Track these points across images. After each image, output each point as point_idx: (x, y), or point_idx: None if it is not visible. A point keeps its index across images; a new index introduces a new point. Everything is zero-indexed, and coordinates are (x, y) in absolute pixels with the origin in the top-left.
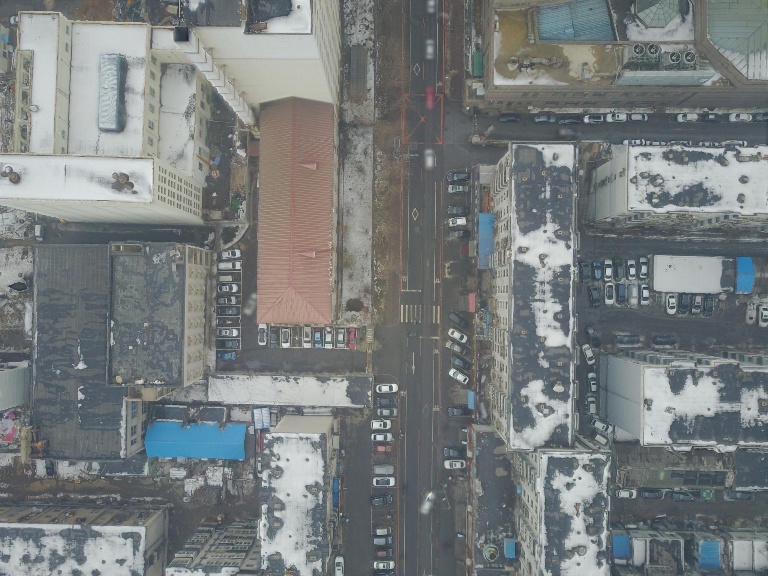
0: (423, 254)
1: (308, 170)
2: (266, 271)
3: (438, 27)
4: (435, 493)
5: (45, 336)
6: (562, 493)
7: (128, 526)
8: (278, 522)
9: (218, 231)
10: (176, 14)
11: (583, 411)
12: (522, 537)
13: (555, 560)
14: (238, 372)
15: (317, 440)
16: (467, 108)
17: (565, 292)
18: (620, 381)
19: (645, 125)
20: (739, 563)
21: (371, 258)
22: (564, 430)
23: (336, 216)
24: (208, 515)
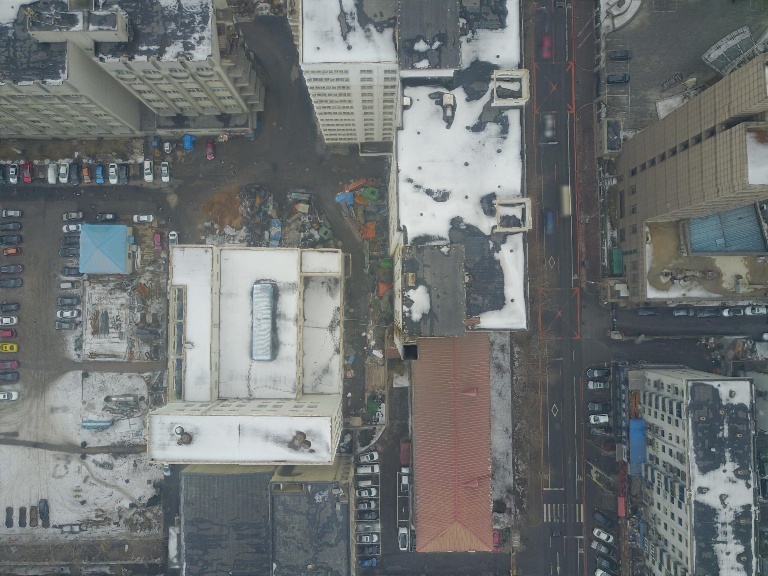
0: (564, 451)
1: (469, 397)
2: (426, 500)
3: (572, 220)
4: None
5: (194, 568)
6: None
7: None
8: None
9: (355, 433)
10: (307, 213)
11: None
12: None
13: None
14: None
15: None
16: (605, 303)
17: (747, 533)
18: None
19: None
20: None
21: (512, 457)
22: None
23: None
24: None
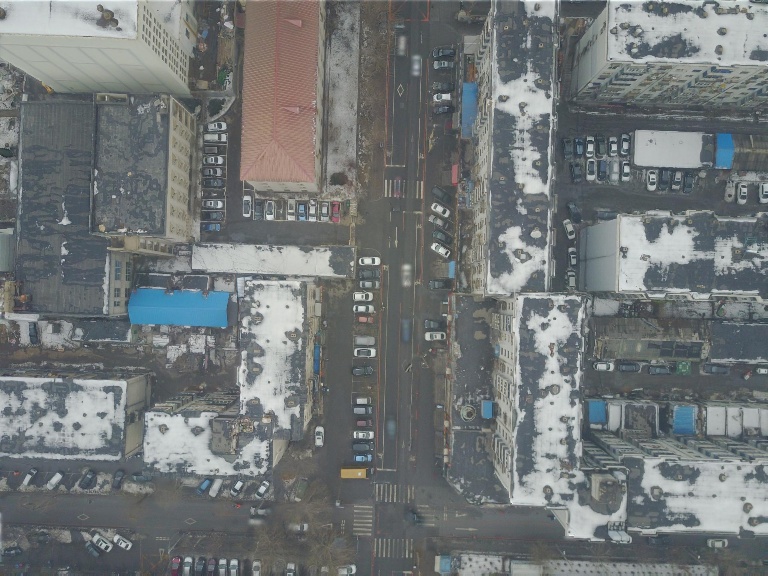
0: (408, 130)
1: (293, 26)
2: (250, 127)
3: None
4: (415, 365)
5: (30, 192)
6: (537, 333)
7: (109, 380)
8: (257, 367)
9: (204, 103)
10: None
11: (563, 286)
12: (499, 395)
13: (529, 398)
14: None
15: (297, 288)
16: None
17: (544, 140)
18: (598, 243)
19: None
20: (712, 428)
21: (356, 133)
22: (540, 276)
23: (322, 89)
24: (190, 384)
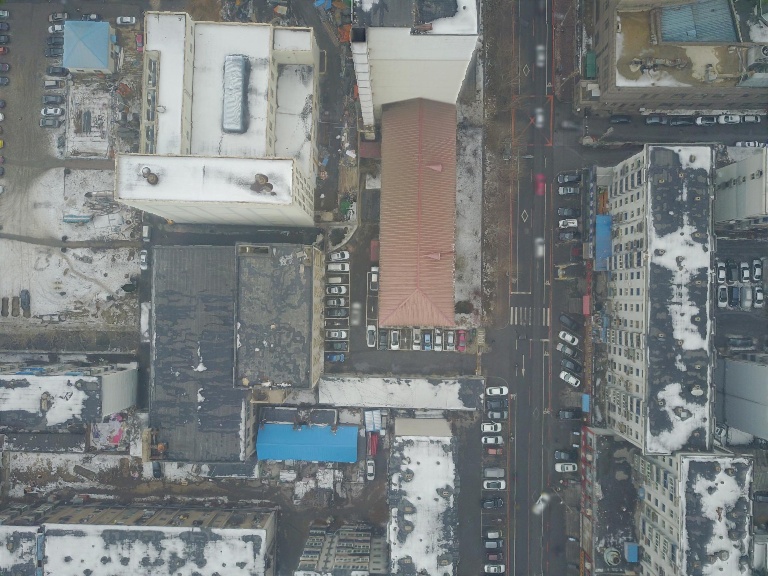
0: (533, 256)
1: (434, 172)
2: (390, 273)
3: (548, 28)
4: (546, 496)
5: (164, 338)
6: (704, 497)
7: (248, 529)
8: (409, 526)
9: (327, 233)
10: (285, 15)
11: None
12: (646, 541)
13: (698, 565)
14: (347, 374)
15: (448, 443)
16: (578, 109)
17: (702, 295)
18: (745, 384)
19: (758, 127)
20: None
21: (480, 260)
22: (702, 434)
23: None
24: (316, 518)
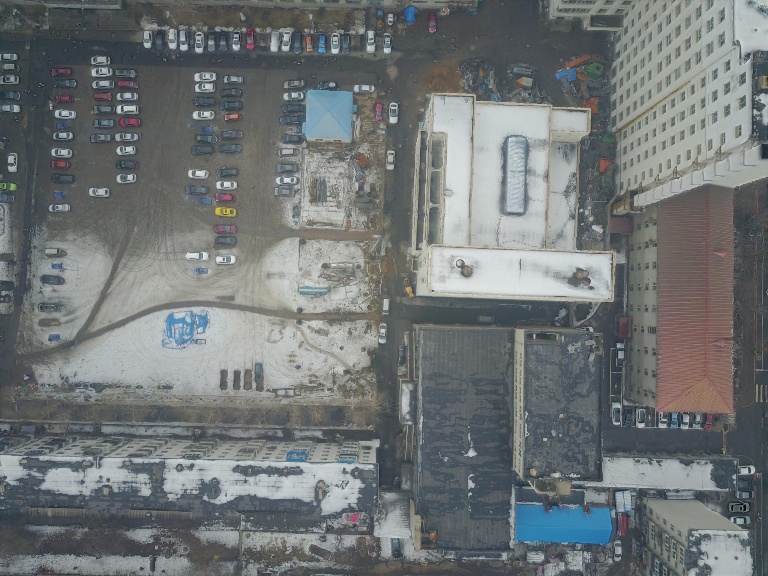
0: None
1: (718, 258)
2: (671, 359)
3: None
4: None
5: (431, 422)
6: None
7: None
8: None
9: (571, 308)
10: (530, 86)
11: None
12: None
13: None
14: None
15: (745, 538)
16: None
17: None
18: None
19: None
20: None
21: None
22: None
23: None
24: None
